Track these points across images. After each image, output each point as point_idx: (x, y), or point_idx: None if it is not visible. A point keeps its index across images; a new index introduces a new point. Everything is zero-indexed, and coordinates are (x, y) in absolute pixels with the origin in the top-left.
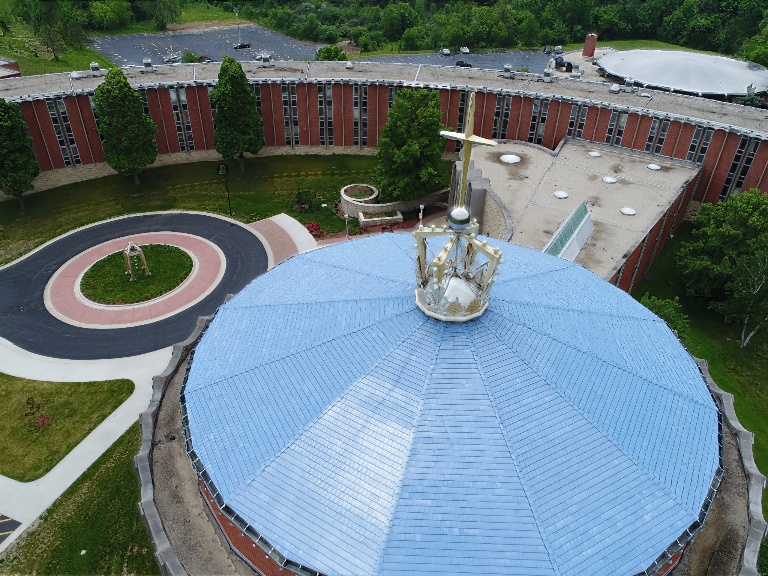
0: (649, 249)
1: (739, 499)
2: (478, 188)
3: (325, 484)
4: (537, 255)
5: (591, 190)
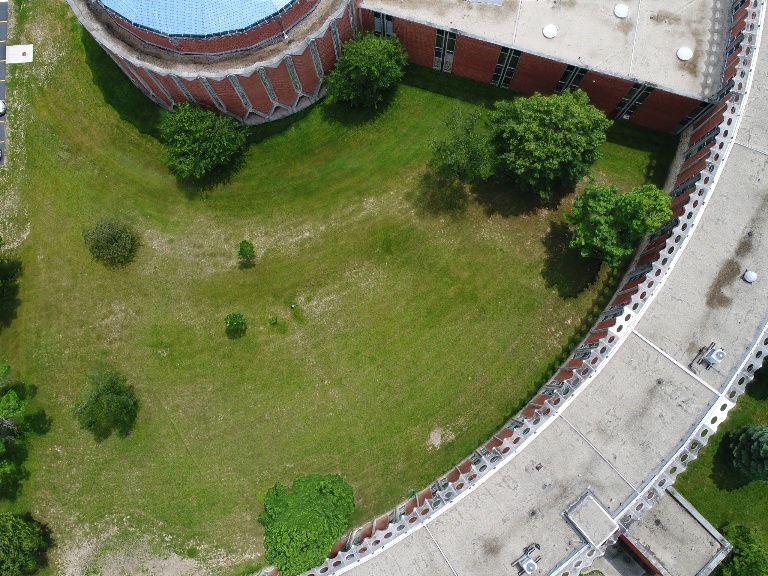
0: (538, 75)
1: (192, 71)
2: None
3: None
4: None
5: None
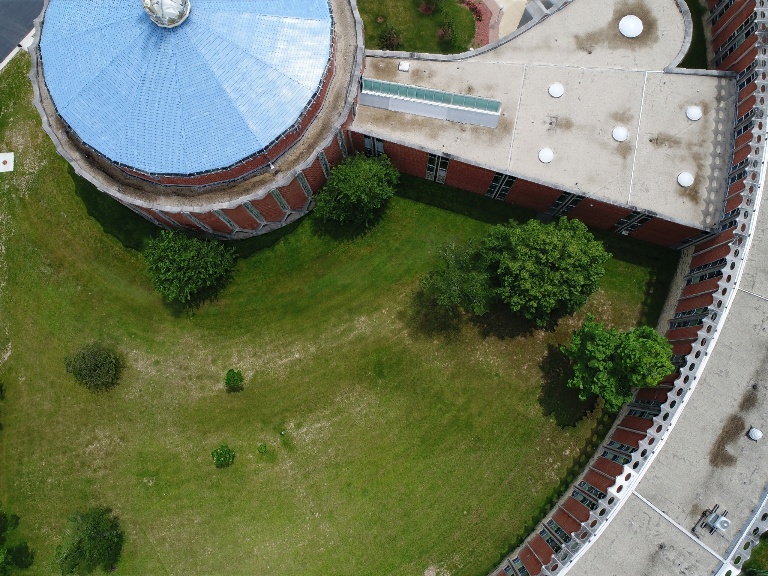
0: (534, 195)
1: (175, 204)
2: (530, 11)
3: (71, 7)
4: (311, 61)
5: (585, 118)
